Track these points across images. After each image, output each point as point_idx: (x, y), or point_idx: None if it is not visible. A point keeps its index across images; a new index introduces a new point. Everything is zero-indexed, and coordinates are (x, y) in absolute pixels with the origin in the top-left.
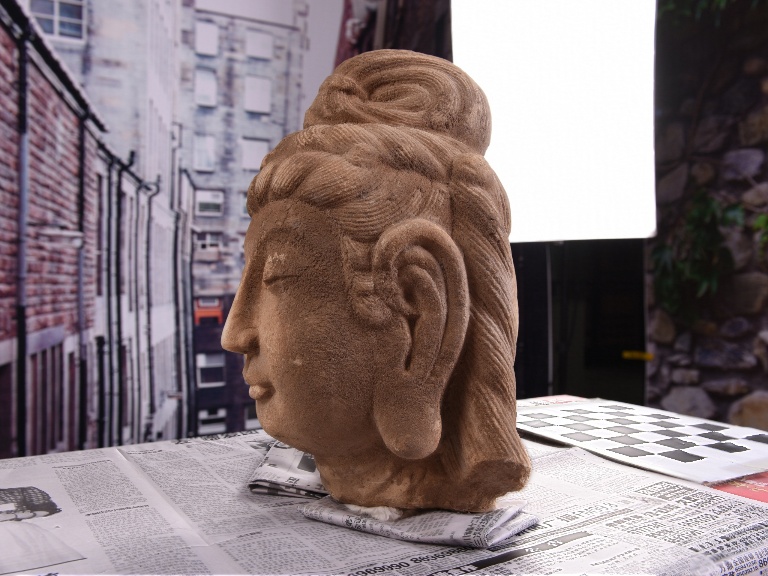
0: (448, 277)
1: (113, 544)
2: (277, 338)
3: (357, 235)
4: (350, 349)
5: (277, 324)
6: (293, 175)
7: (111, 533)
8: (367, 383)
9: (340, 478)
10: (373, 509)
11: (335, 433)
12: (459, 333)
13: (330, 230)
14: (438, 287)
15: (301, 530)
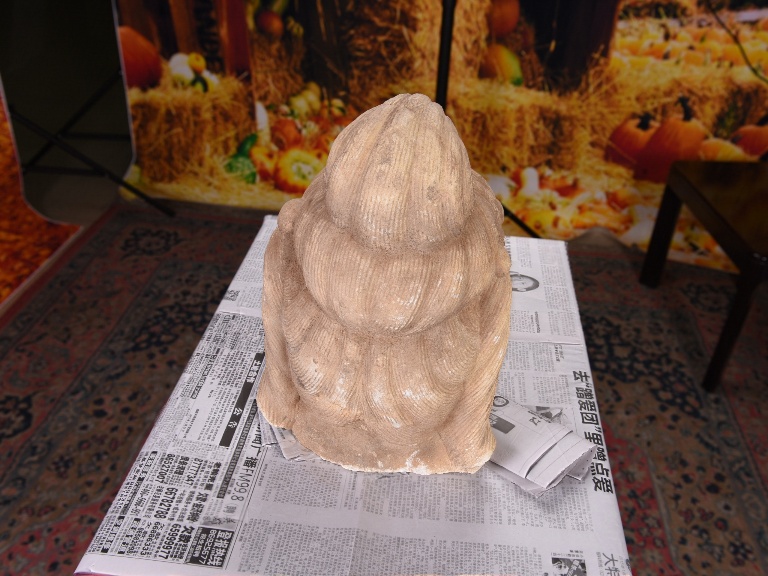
0: None
1: None
2: None
3: None
4: None
5: None
6: None
7: None
8: None
9: None
10: None
11: None
12: None
13: None
14: None
15: None
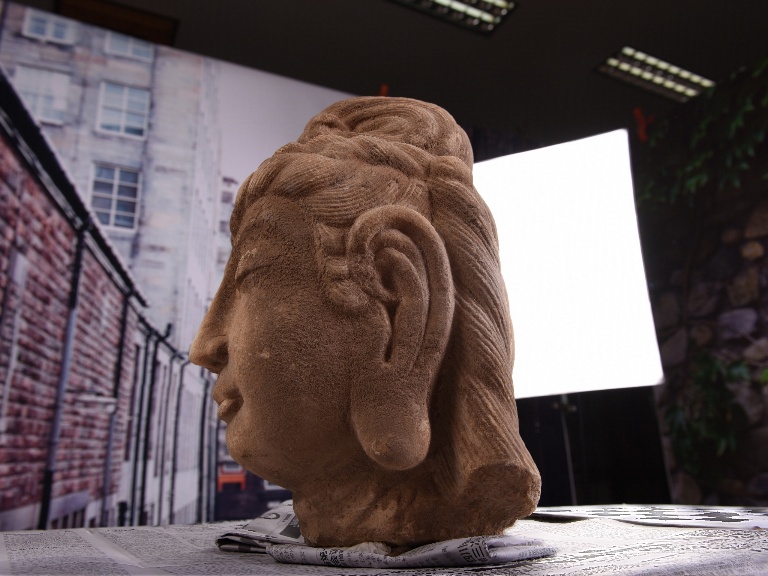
0: (428, 261)
1: (25, 559)
2: (244, 332)
3: (330, 220)
4: (323, 339)
5: (245, 319)
6: (267, 171)
7: (30, 556)
8: (342, 377)
9: (317, 510)
10: (355, 547)
11: (307, 441)
12: (444, 319)
13: (303, 218)
14: (418, 271)
15: (265, 565)
